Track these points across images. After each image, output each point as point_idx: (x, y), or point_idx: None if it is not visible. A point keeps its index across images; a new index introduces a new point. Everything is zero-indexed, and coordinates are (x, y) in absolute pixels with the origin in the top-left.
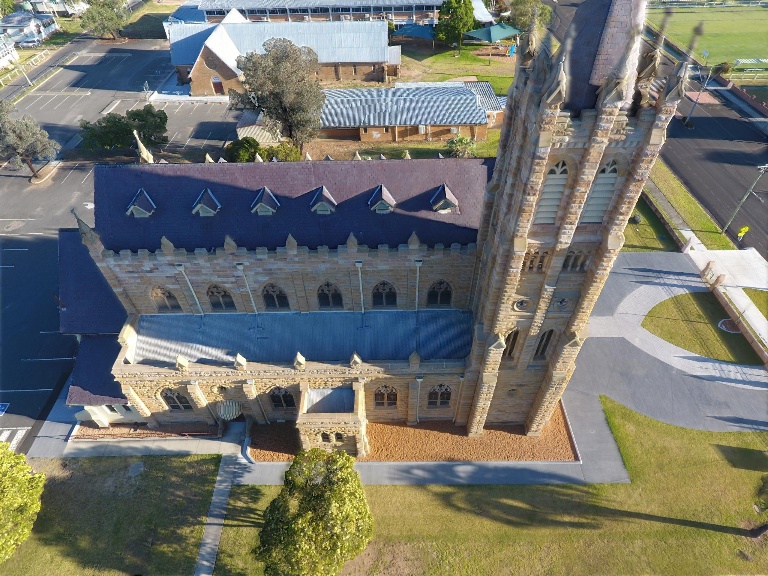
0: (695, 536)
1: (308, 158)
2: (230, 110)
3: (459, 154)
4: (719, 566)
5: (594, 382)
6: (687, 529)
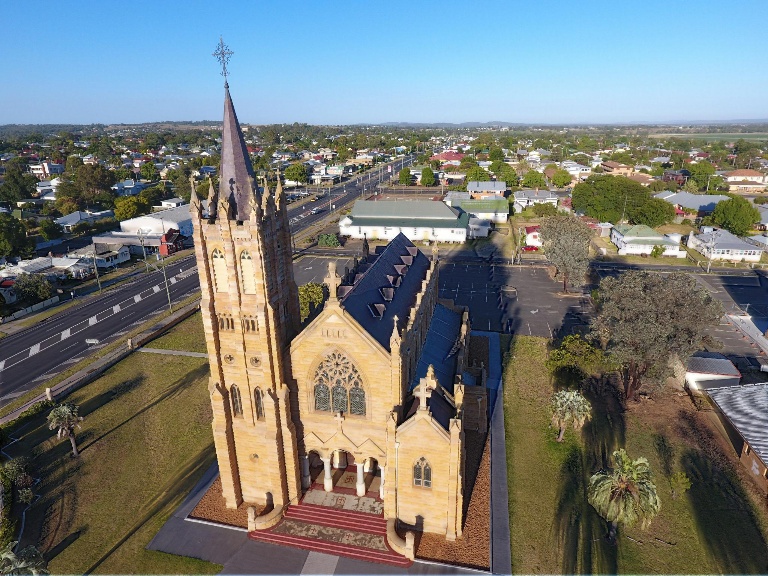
0: (79, 571)
1: (423, 284)
2: (746, 358)
3: (610, 474)
4: (53, 575)
5: (238, 569)
6: (87, 568)
